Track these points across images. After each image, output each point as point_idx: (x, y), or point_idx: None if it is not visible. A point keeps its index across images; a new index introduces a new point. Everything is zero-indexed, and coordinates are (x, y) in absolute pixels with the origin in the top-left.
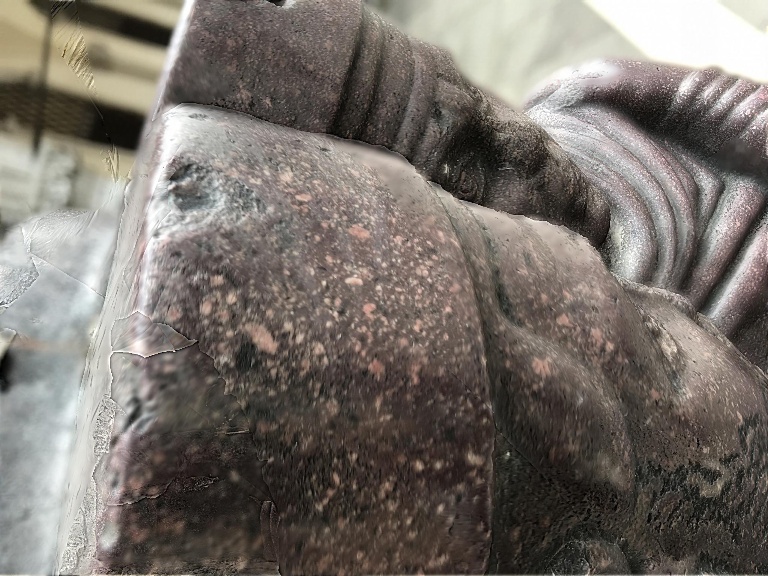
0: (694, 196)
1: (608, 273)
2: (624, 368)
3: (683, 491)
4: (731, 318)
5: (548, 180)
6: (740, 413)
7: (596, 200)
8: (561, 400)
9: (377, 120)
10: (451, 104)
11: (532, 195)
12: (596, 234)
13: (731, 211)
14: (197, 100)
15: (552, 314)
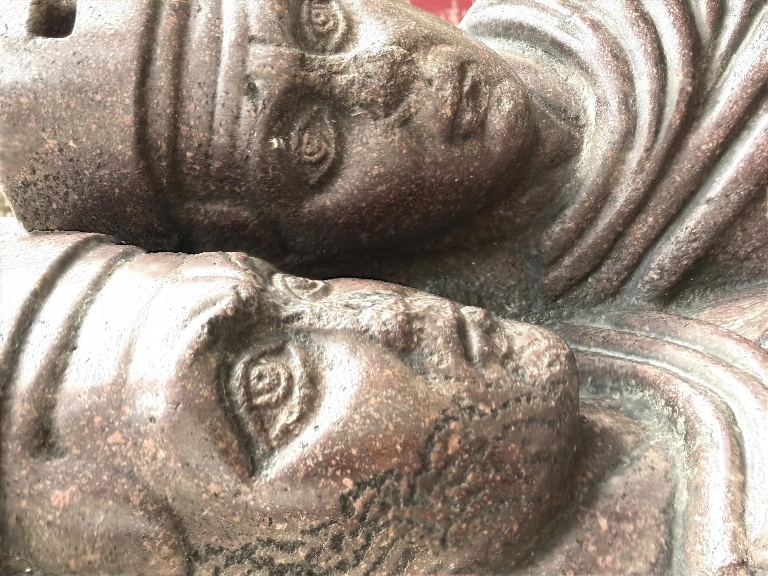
0: (714, 23)
1: (187, 372)
2: (176, 472)
3: (251, 563)
4: (739, 195)
5: (415, 110)
6: (351, 478)
7: (504, 103)
8: (78, 523)
9: (188, 118)
10: (264, 72)
11: (393, 135)
12: (504, 146)
13: (763, 38)
14: (19, 160)
15: (103, 435)
